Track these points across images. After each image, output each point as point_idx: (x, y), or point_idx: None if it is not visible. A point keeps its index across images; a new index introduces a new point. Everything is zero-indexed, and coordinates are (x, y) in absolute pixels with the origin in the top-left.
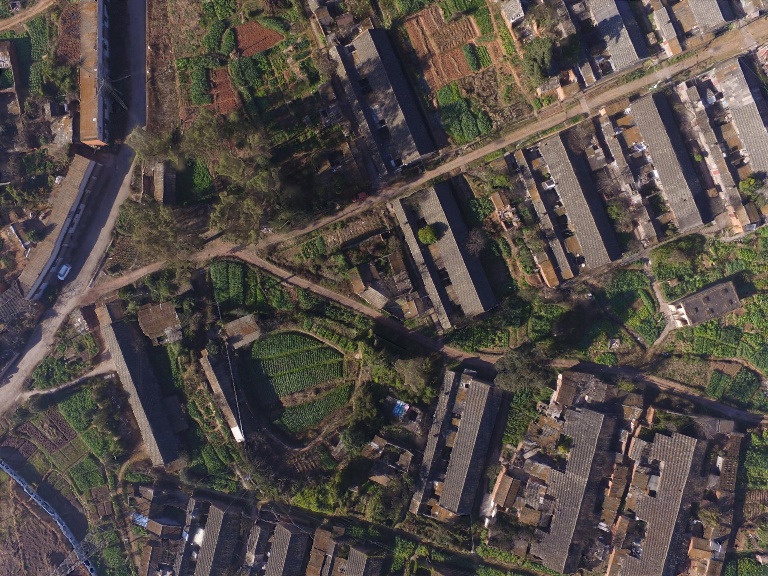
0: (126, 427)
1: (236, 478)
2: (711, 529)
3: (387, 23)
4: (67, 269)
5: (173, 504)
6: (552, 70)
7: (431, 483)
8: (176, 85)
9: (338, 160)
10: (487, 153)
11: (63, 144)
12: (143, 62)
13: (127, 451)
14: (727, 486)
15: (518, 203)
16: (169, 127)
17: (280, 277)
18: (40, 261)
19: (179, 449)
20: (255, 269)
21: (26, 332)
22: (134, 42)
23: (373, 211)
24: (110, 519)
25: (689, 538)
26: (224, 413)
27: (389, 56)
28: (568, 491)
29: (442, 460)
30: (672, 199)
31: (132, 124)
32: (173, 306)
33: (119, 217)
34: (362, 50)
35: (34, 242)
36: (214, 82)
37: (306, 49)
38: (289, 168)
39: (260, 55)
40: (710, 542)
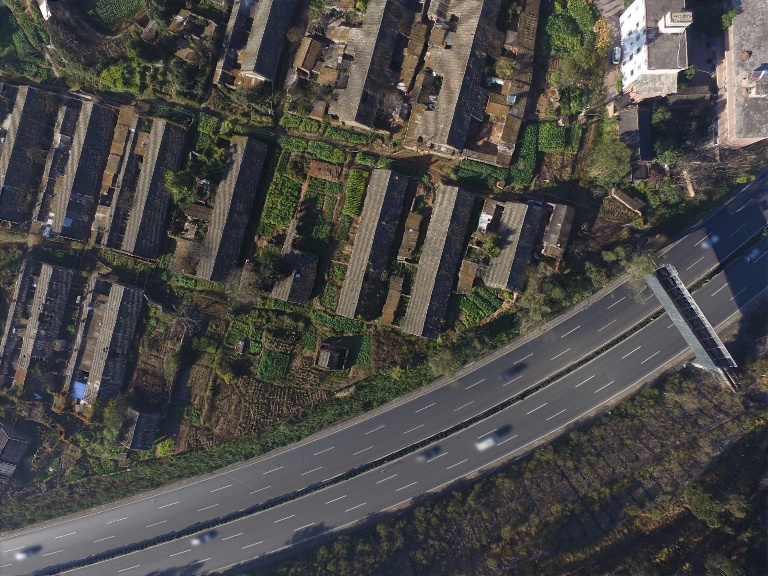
0: None
1: (46, 63)
2: (509, 85)
3: None
4: None
5: None
6: None
7: (233, 52)
8: None
9: None
10: None
11: None
12: None
13: None
14: (526, 44)
15: None
16: None
17: None
18: None
19: None
20: None
21: None
22: None
23: None
24: None
25: (487, 95)
26: None
27: None
28: (363, 43)
29: (246, 32)
30: None
31: None
32: None
33: None
34: None
35: None
36: None
37: None
38: None
39: None
40: (507, 97)
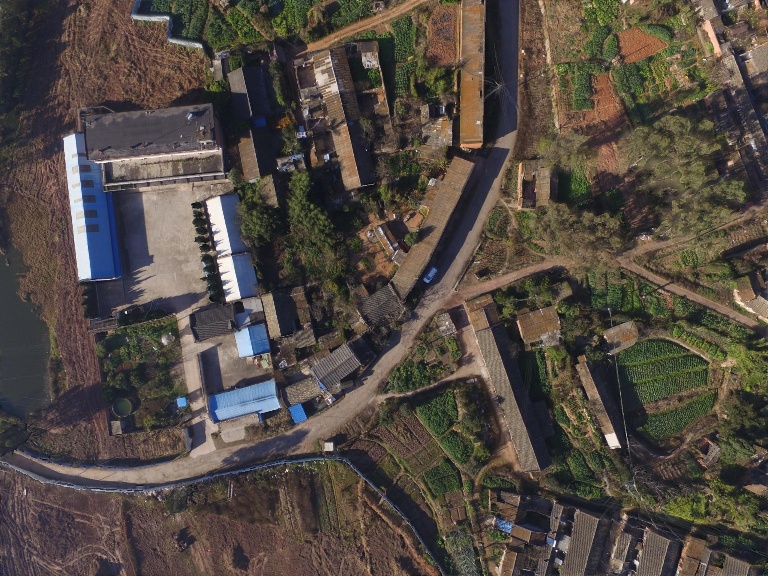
0: (488, 432)
1: (602, 485)
2: None
3: None
4: (435, 272)
5: (536, 510)
6: None
7: None
8: (555, 90)
9: (725, 169)
10: None
11: (440, 146)
12: (515, 66)
13: (489, 456)
14: None
15: None
16: (541, 131)
17: (657, 284)
18: (416, 263)
19: (551, 455)
20: (632, 276)
21: (387, 334)
22: (506, 45)
23: (755, 220)
24: (464, 524)
25: None
26: (598, 419)
27: None
28: None
29: None
30: None
31: (503, 128)
32: (555, 311)
33: (488, 221)
34: (761, 60)
35: (409, 244)
36: (595, 88)
37: (691, 57)
38: None
39: (645, 62)
40: None
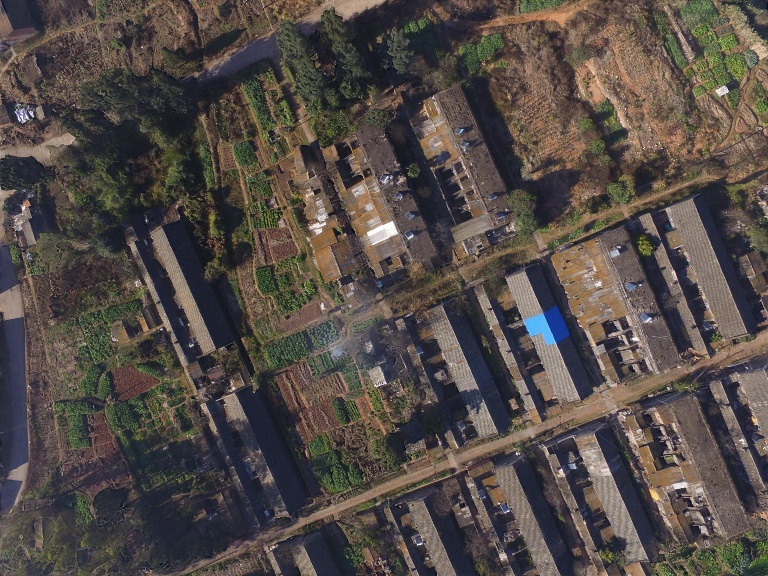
0: None
1: None
2: None
3: (254, 385)
4: None
5: None
6: (416, 435)
7: None
8: (55, 427)
9: (214, 508)
10: (359, 503)
11: None
12: (24, 398)
13: None
14: None
15: (389, 554)
16: (51, 463)
17: None
18: None
19: None
20: None
21: None
22: (14, 379)
23: (251, 553)
24: None
25: None
26: None
27: (258, 414)
28: None
29: None
30: (536, 560)
31: (15, 460)
32: None
33: (5, 552)
34: (232, 408)
35: None
36: (92, 426)
37: (180, 395)
38: (168, 510)
39: (135, 401)
40: None
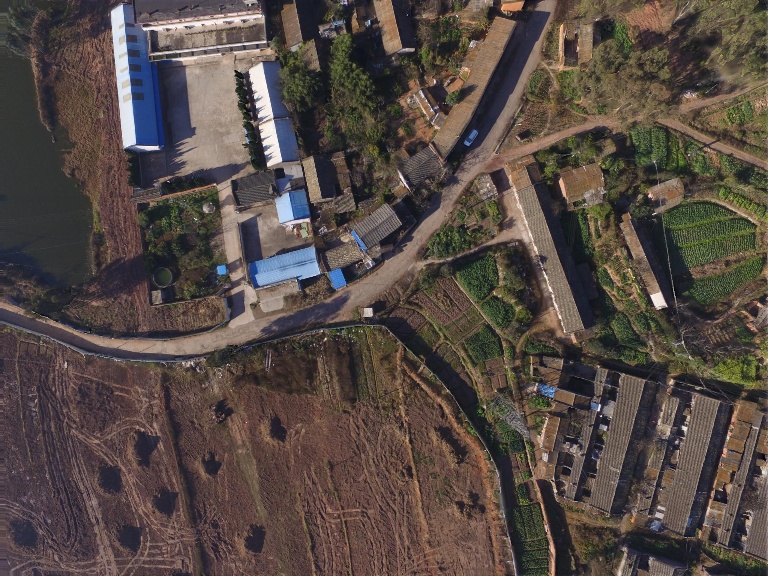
0: (529, 296)
1: (648, 349)
2: None
3: None
4: (476, 134)
5: (580, 375)
6: None
7: None
8: None
9: None
10: None
11: (481, 8)
12: None
13: (531, 320)
14: None
15: None
16: None
17: (703, 142)
18: (458, 122)
19: (595, 316)
20: (677, 134)
21: None
22: None
23: None
24: (505, 392)
25: None
26: (644, 279)
27: None
28: None
29: None
30: None
31: None
32: (599, 168)
33: (529, 83)
34: None
35: (451, 104)
36: None
37: None
38: None
39: None
40: None
